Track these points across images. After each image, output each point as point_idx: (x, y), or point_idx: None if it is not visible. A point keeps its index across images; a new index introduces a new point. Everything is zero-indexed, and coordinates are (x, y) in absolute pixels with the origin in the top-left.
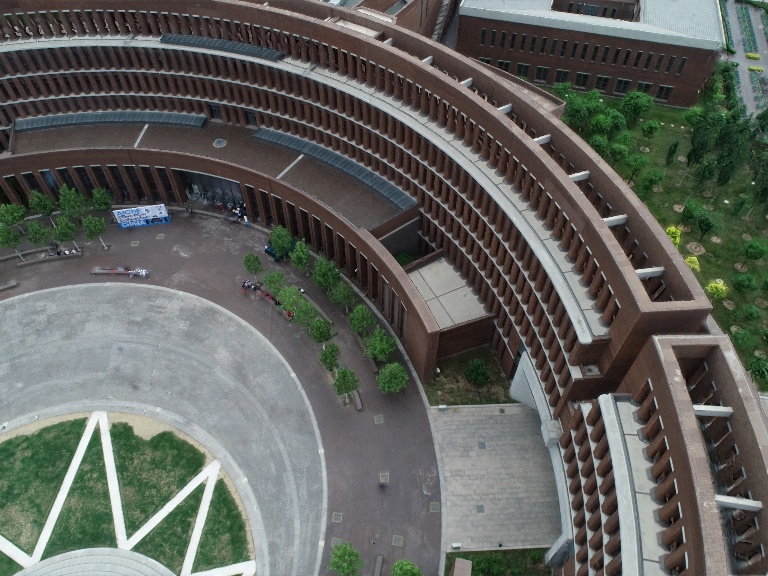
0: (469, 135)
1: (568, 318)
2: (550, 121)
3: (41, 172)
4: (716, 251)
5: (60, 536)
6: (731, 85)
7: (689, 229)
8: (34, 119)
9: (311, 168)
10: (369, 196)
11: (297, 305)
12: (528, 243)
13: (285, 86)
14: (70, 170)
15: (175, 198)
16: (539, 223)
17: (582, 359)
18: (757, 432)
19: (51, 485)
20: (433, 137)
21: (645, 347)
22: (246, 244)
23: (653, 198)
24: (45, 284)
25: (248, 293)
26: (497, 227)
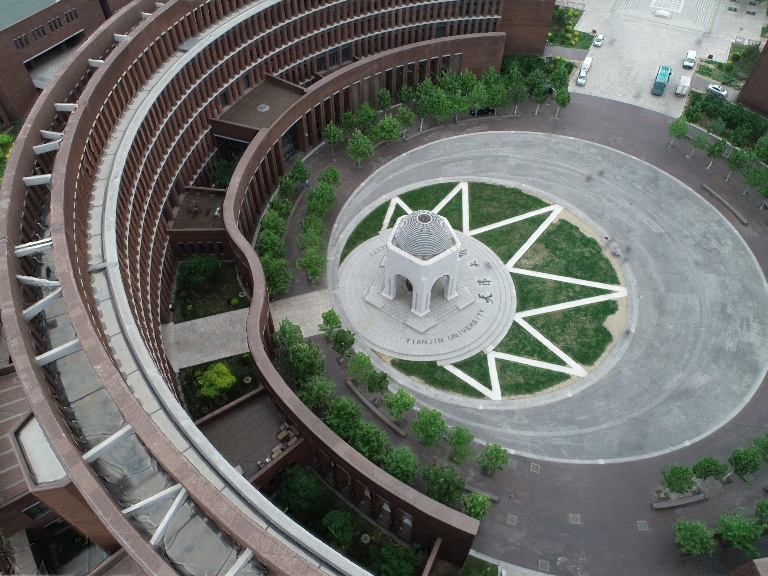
0: None
1: None
2: None
3: None
4: None
5: (526, 280)
6: None
7: None
8: None
9: None
10: None
11: None
12: None
13: None
14: None
15: None
16: None
17: None
18: None
19: (563, 270)
20: None
21: None
22: None
23: None
24: (752, 242)
25: None
26: None
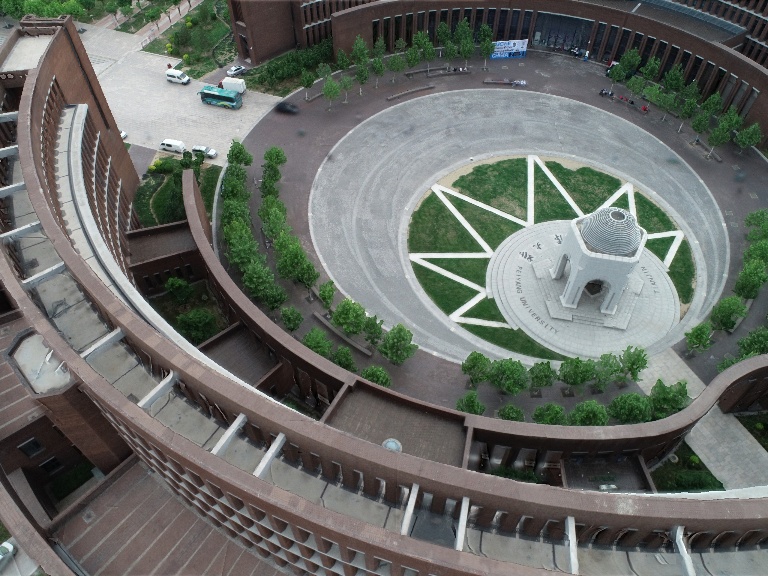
0: None
1: None
2: None
3: (442, 11)
4: None
5: (541, 213)
6: None
7: None
8: None
9: (651, 11)
10: (705, 27)
11: (659, 98)
12: None
13: None
14: (461, 11)
15: None
16: None
17: None
18: None
19: (521, 189)
20: None
21: None
22: (589, 71)
23: None
24: (453, 87)
25: (605, 98)
26: None
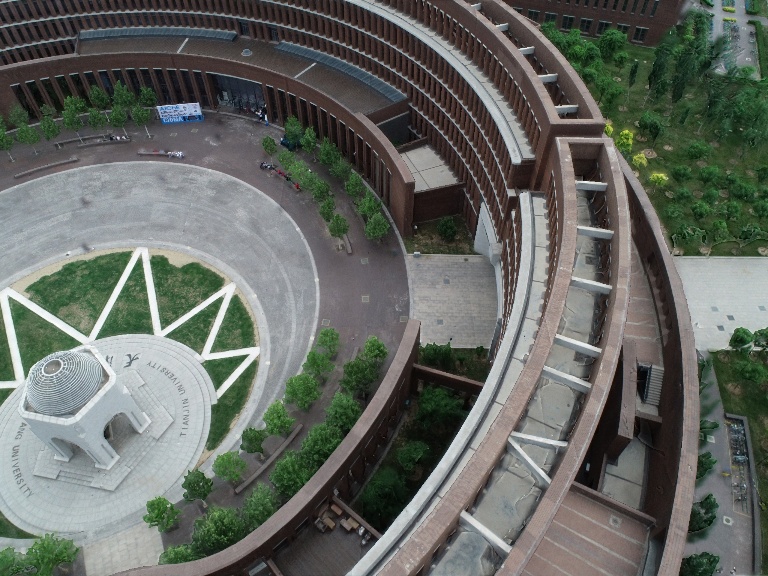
0: (446, 30)
1: (506, 150)
2: (508, 11)
3: (100, 72)
4: (666, 156)
5: (110, 325)
6: (701, 28)
7: (645, 139)
8: (95, 31)
9: (321, 72)
10: (368, 93)
11: (304, 176)
12: (483, 103)
13: (302, 1)
14: (123, 72)
15: (208, 101)
16: (494, 91)
17: (516, 181)
18: (617, 189)
19: (104, 293)
20: (418, 33)
21: (551, 148)
22: None
23: (618, 115)
24: (100, 160)
25: (265, 172)
26: (464, 100)
